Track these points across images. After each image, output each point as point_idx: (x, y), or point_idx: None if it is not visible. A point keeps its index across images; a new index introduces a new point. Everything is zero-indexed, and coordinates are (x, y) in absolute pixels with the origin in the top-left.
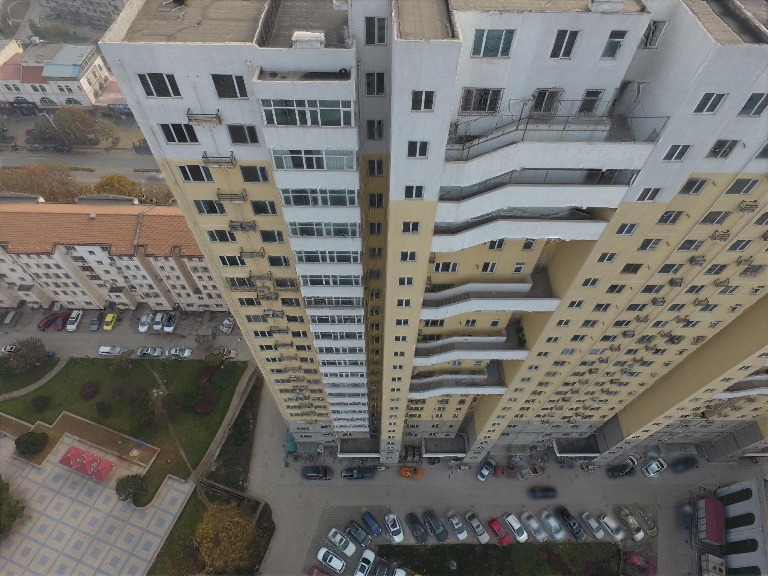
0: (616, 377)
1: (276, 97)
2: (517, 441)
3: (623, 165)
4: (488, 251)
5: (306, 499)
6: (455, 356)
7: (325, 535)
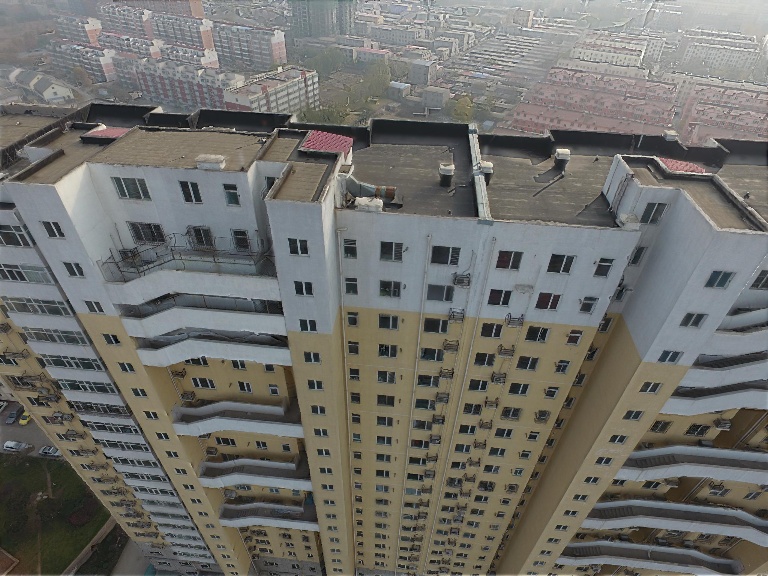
0: (454, 526)
1: None
2: None
3: (262, 296)
4: (234, 370)
5: None
6: (239, 480)
7: None
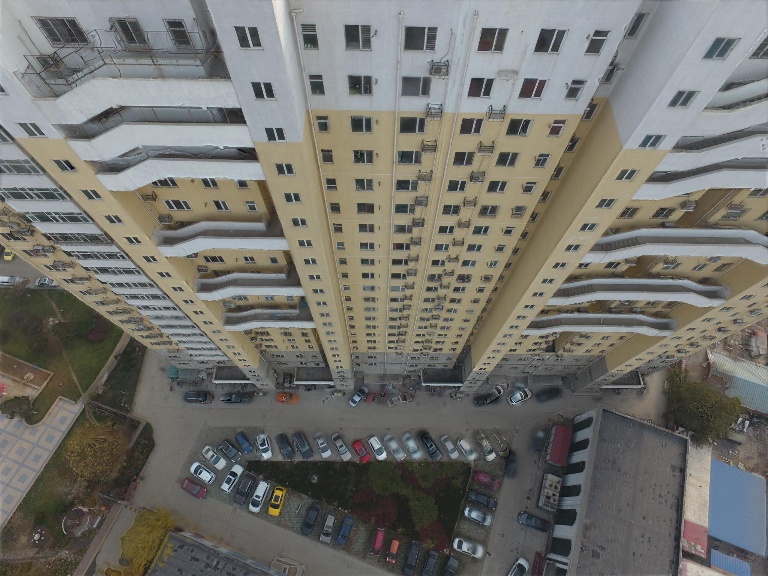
0: (435, 313)
1: None
2: (389, 371)
3: (218, 103)
4: (206, 189)
5: (186, 420)
6: (234, 292)
7: (200, 451)
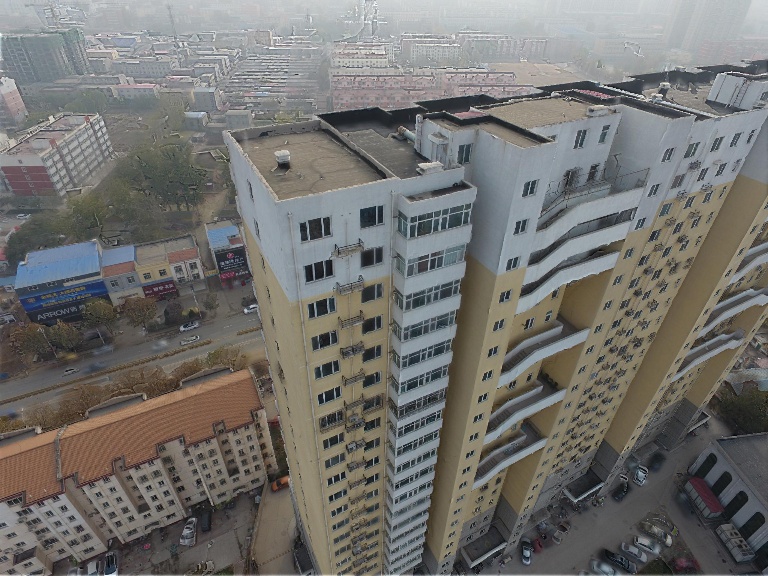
0: (605, 396)
1: (423, 212)
2: (536, 507)
3: (629, 206)
4: None
5: None
6: (515, 419)
7: None
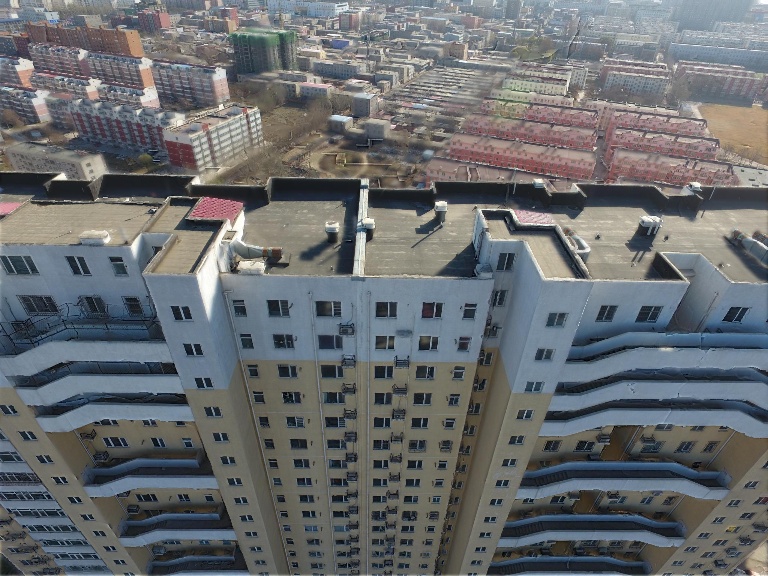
0: (388, 558)
1: None
2: None
3: (155, 359)
4: (145, 427)
5: None
6: (161, 536)
7: None
